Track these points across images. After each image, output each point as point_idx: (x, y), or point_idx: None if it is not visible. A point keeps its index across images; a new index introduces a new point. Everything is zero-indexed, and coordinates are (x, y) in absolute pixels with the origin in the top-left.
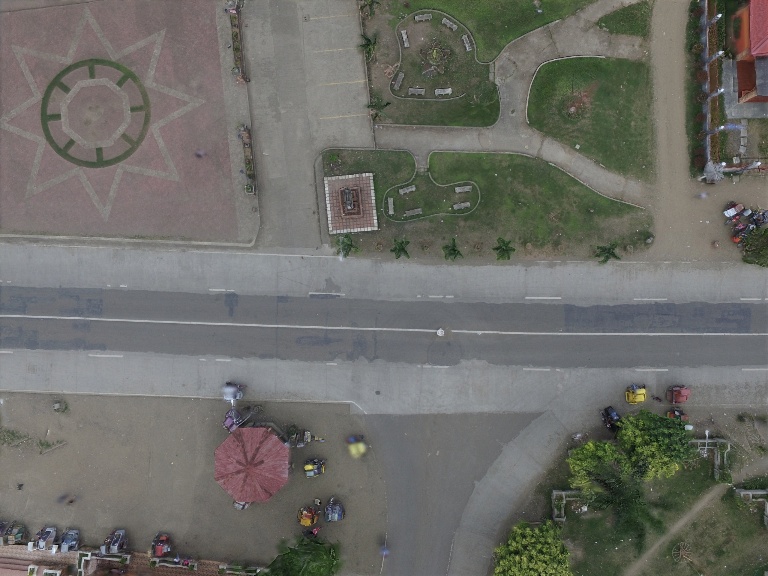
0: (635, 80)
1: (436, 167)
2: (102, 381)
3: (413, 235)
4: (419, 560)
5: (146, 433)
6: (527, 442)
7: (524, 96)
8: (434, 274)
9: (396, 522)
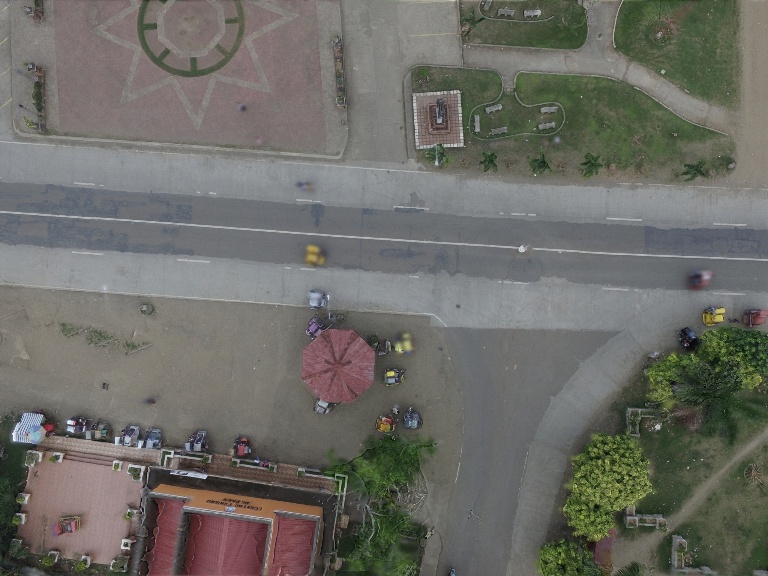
0: (722, 8)
1: (522, 87)
2: (189, 285)
3: (498, 153)
4: (493, 471)
5: (230, 338)
6: (603, 360)
7: (611, 21)
8: (517, 192)
9: (472, 433)
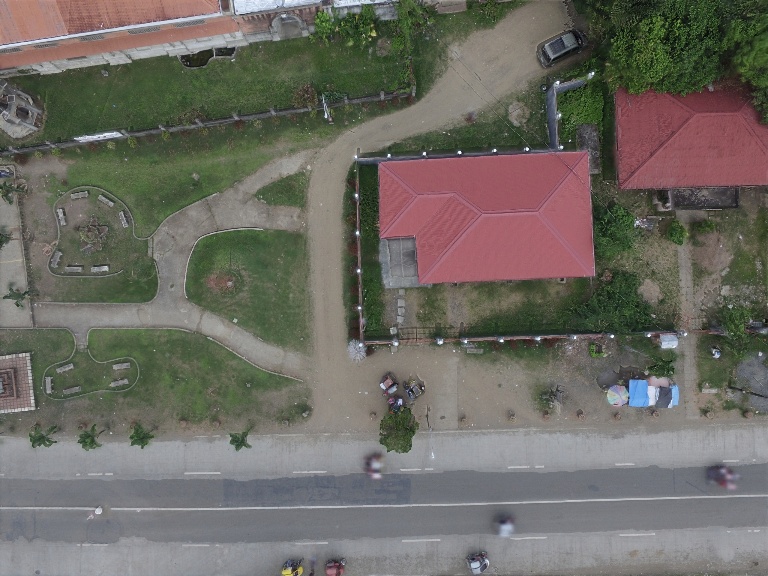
0: (293, 252)
1: (95, 344)
2: None
3: (72, 413)
4: None
5: None
6: None
7: (183, 270)
8: (93, 452)
9: None
